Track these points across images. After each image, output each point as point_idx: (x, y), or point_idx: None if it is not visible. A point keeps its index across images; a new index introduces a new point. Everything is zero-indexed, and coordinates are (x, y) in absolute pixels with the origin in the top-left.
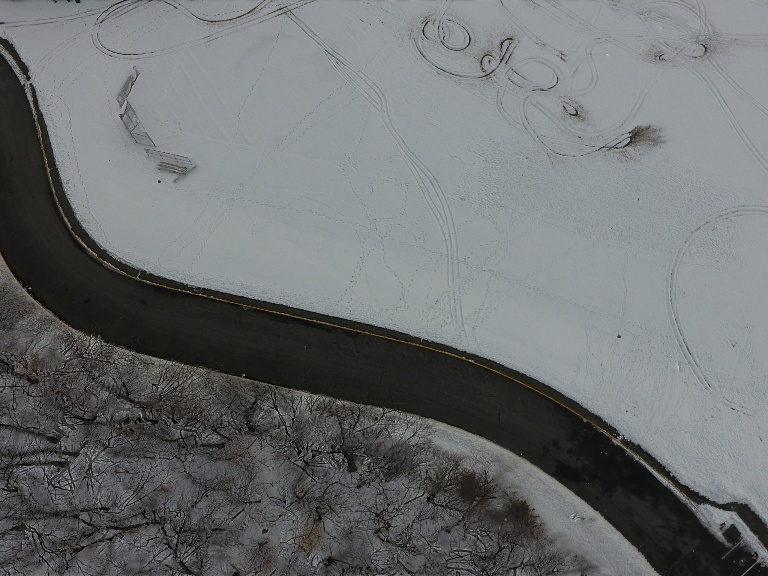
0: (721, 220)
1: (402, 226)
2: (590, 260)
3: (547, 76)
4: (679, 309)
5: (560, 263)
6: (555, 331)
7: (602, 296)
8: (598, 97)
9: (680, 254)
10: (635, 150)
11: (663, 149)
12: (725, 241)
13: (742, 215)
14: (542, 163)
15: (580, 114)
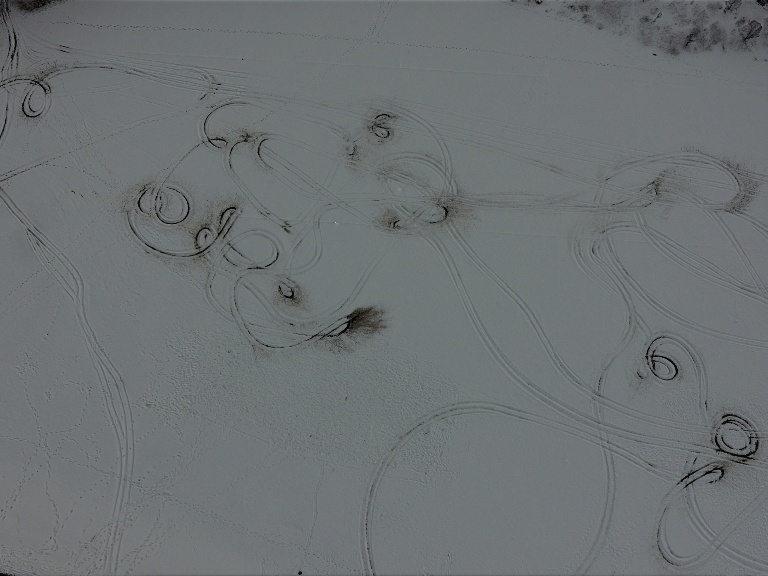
0: (436, 421)
1: (75, 441)
2: (281, 476)
3: (266, 251)
4: (373, 535)
5: (246, 481)
6: (226, 570)
7: (288, 522)
8: (319, 275)
9: (384, 465)
10: (351, 338)
11: (382, 336)
12: (437, 447)
13: (461, 414)
14: (245, 357)
15: (296, 296)
